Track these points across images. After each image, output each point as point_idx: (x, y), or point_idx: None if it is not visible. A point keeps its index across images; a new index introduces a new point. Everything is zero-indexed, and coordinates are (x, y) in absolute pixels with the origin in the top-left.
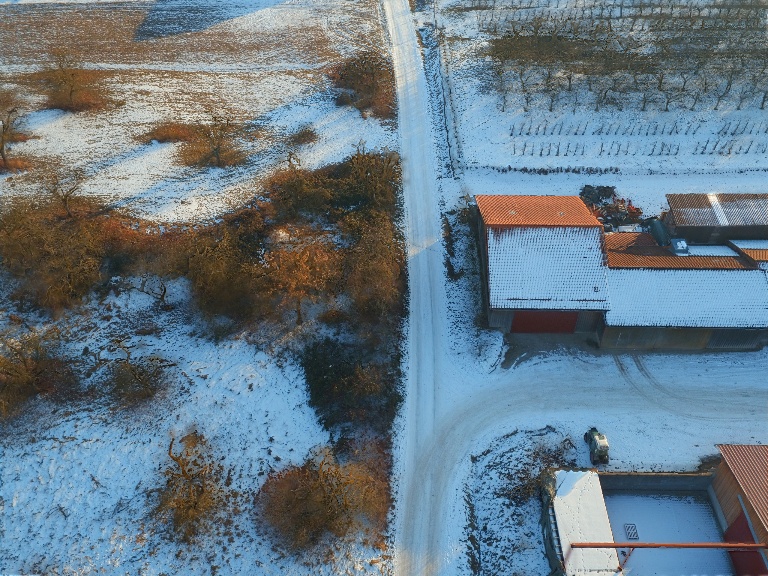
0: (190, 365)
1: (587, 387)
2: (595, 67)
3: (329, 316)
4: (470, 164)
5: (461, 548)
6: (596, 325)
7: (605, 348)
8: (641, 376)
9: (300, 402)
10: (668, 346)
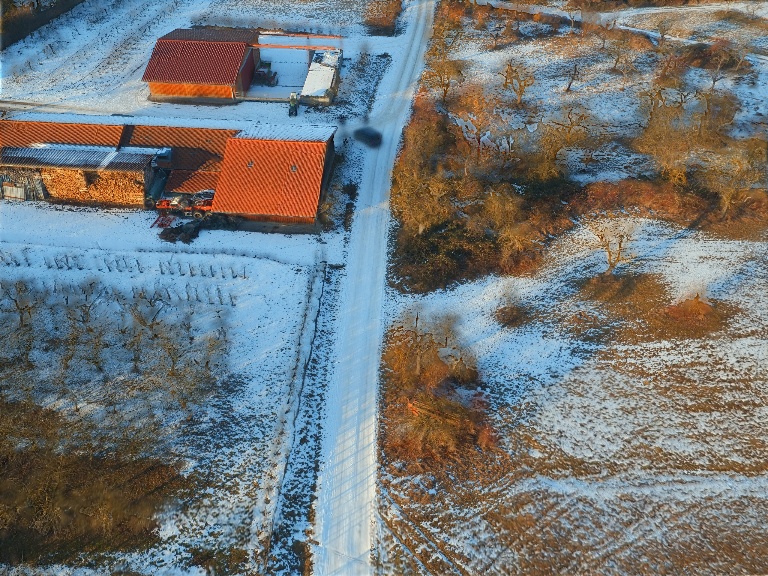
0: None
1: None
2: (7, 427)
3: None
4: (304, 268)
5: None
6: None
7: None
8: None
9: None
10: None
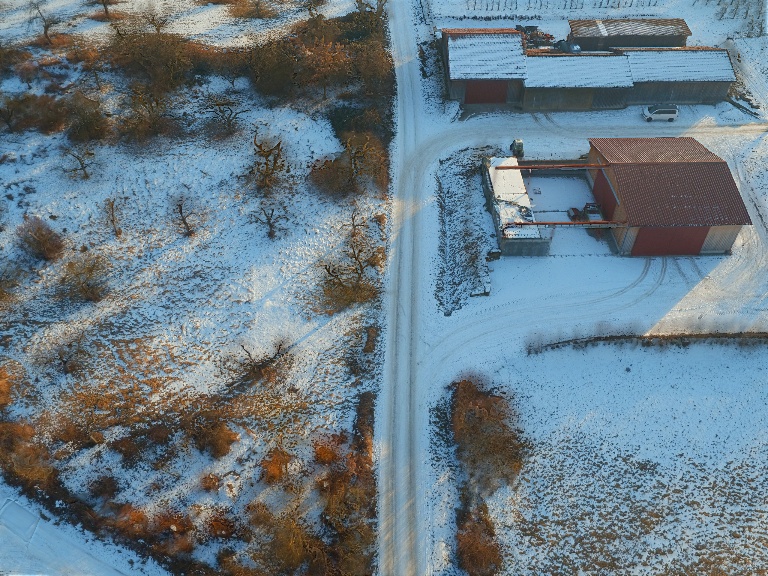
0: (255, 119)
1: (513, 128)
2: None
3: (344, 94)
4: (437, 15)
5: (433, 199)
6: (520, 96)
7: (526, 109)
8: (548, 122)
9: (329, 136)
10: (567, 107)
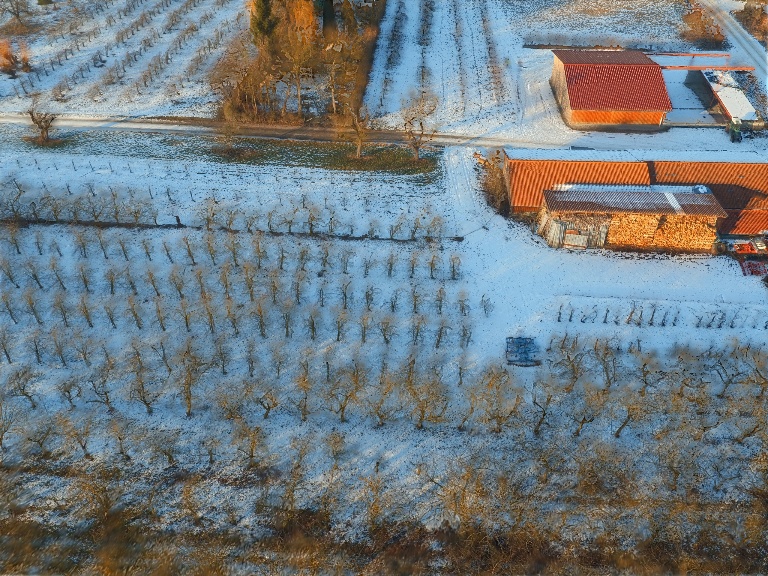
0: None
1: None
2: None
3: None
4: None
5: None
6: None
7: None
8: None
9: None
10: None
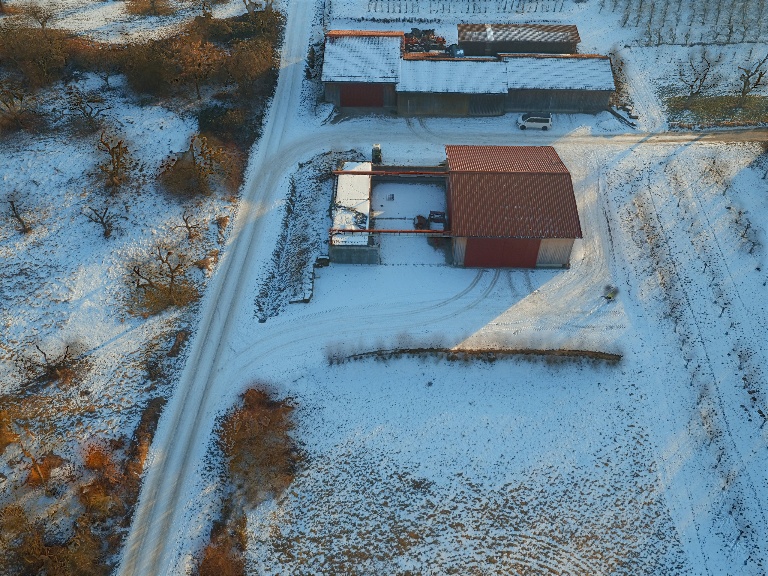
0: (123, 117)
1: (383, 132)
2: None
3: (219, 94)
4: (336, 17)
5: (282, 202)
6: (396, 100)
7: (401, 114)
8: (420, 128)
9: (192, 135)
10: (443, 113)
